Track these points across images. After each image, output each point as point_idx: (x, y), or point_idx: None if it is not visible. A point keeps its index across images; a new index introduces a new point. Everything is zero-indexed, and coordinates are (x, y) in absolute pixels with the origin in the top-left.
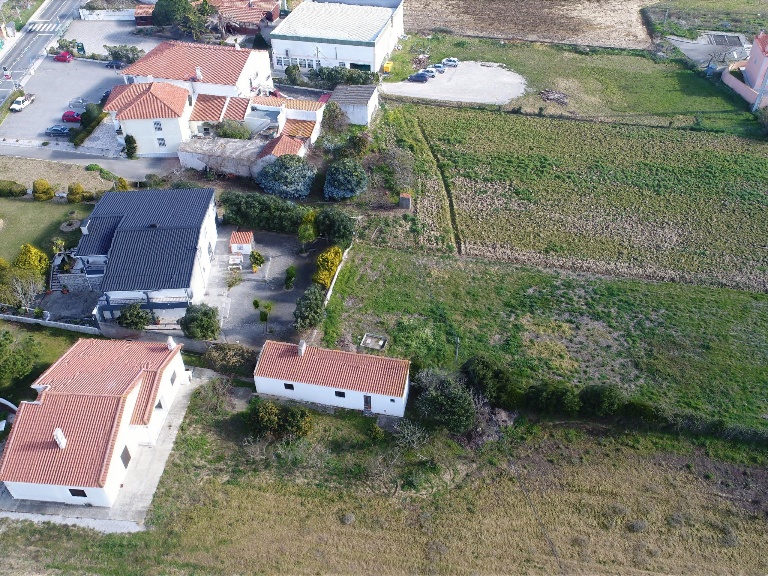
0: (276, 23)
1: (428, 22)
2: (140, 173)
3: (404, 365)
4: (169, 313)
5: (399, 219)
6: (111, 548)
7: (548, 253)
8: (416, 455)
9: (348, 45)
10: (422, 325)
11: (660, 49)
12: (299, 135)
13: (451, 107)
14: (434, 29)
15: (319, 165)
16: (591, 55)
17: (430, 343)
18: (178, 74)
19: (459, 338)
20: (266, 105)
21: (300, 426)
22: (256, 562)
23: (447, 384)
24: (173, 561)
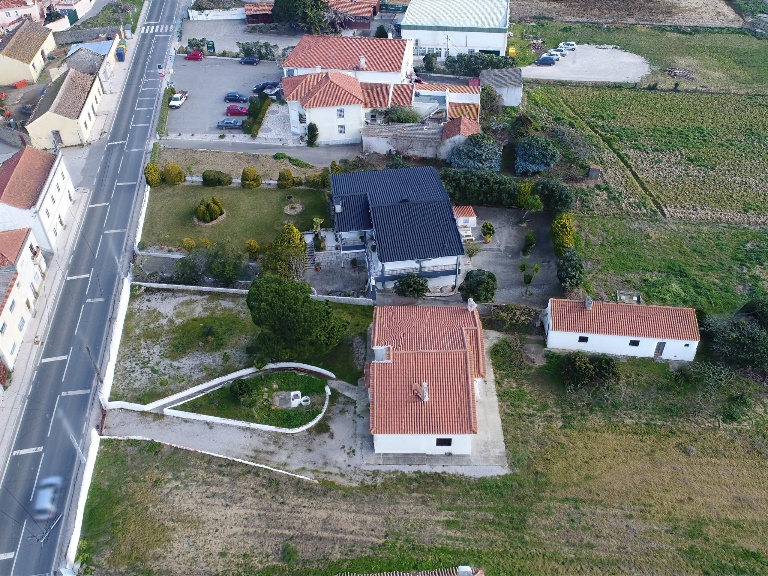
0: (379, 17)
1: (524, 10)
2: (327, 159)
3: (690, 312)
4: (432, 282)
5: (593, 189)
6: (490, 490)
7: (747, 212)
8: (725, 392)
9: (479, 32)
10: (667, 281)
11: (757, 26)
12: (466, 117)
13: (588, 87)
14: (535, 16)
15: (505, 143)
16: (694, 34)
17: (682, 296)
18: (340, 64)
19: (707, 290)
20: (429, 90)
21: (615, 372)
22: (628, 492)
23: (742, 326)
24: (552, 497)
